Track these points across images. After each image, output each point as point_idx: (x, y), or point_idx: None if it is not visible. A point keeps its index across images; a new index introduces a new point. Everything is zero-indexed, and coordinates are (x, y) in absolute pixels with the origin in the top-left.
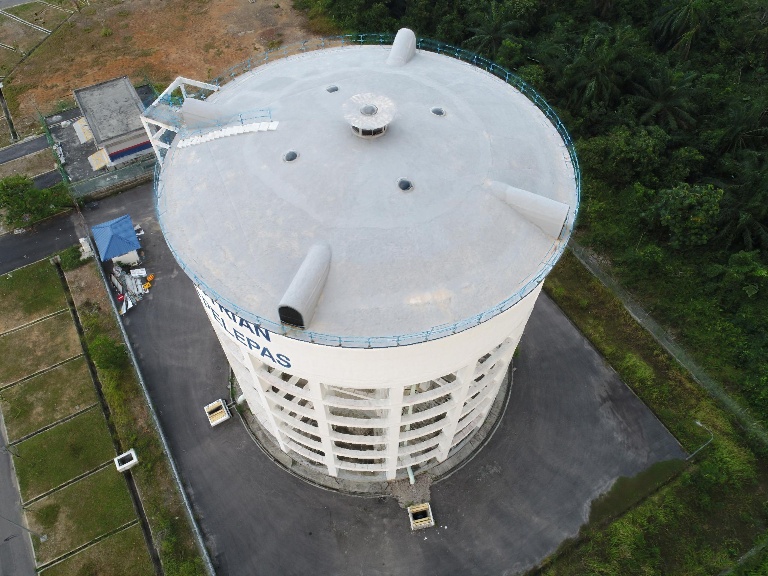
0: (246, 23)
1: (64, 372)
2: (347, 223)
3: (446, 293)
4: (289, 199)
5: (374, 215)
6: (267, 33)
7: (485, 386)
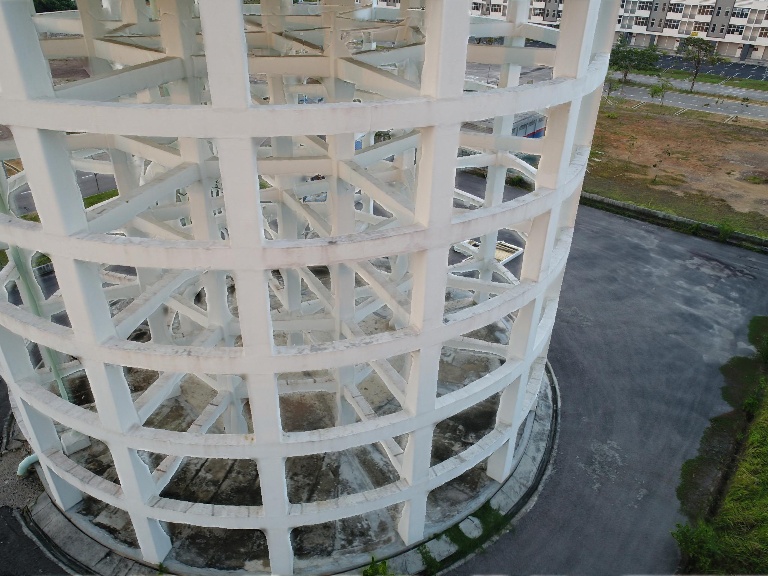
0: (756, 161)
1: None
2: None
3: None
4: None
5: None
6: (767, 173)
7: (262, 546)
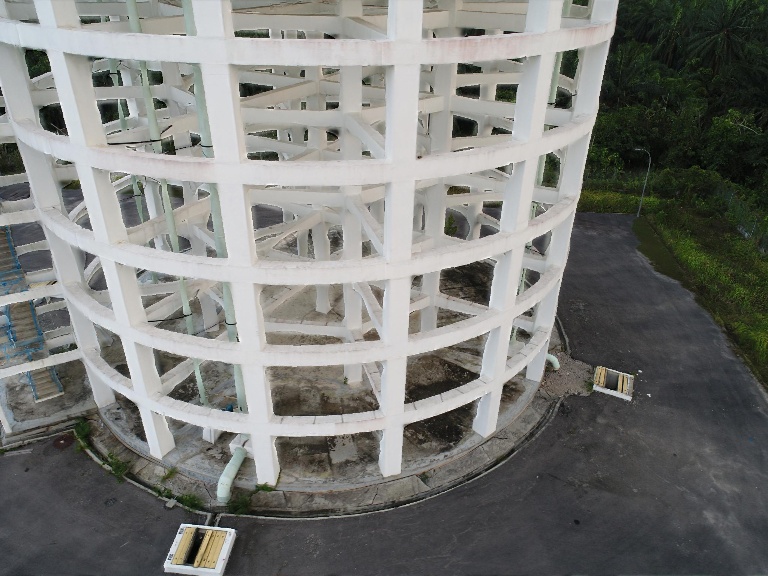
0: None
1: None
2: None
3: None
4: None
5: None
6: None
7: None
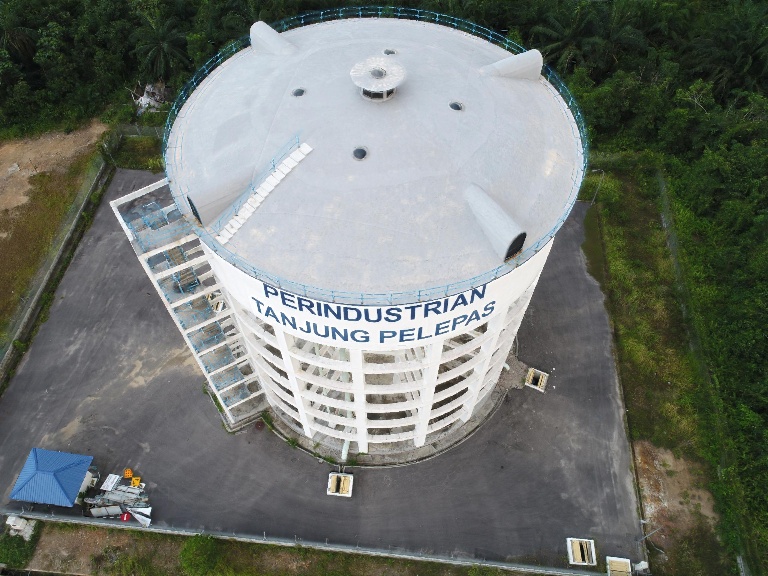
0: None
1: None
2: (462, 159)
3: (553, 152)
4: (406, 180)
5: (469, 140)
6: None
7: None
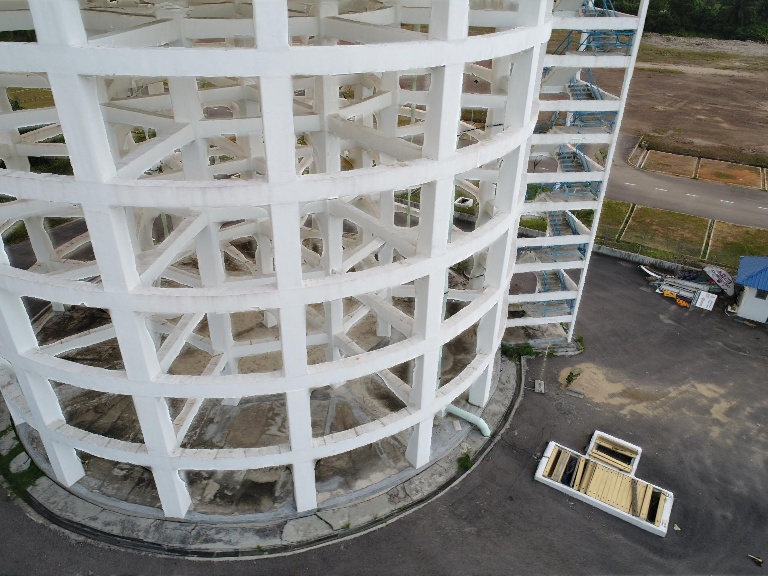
0: None
1: (609, 226)
2: None
3: None
4: None
5: None
6: None
7: None
